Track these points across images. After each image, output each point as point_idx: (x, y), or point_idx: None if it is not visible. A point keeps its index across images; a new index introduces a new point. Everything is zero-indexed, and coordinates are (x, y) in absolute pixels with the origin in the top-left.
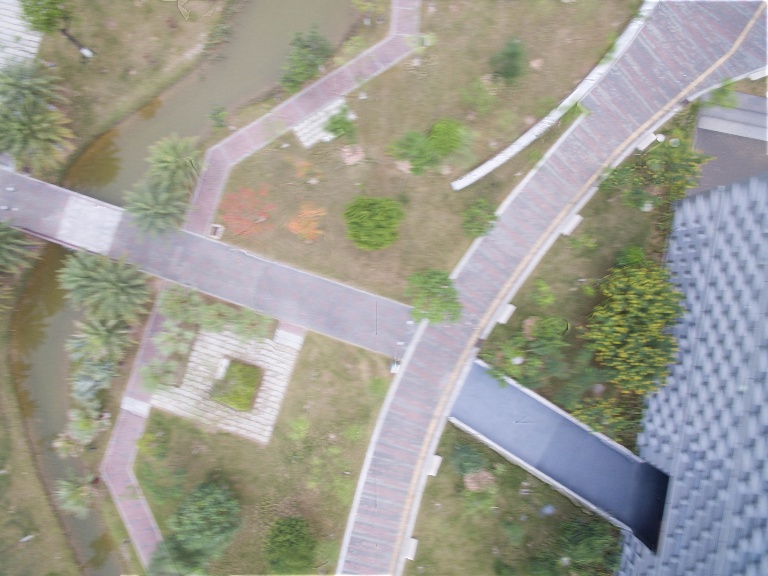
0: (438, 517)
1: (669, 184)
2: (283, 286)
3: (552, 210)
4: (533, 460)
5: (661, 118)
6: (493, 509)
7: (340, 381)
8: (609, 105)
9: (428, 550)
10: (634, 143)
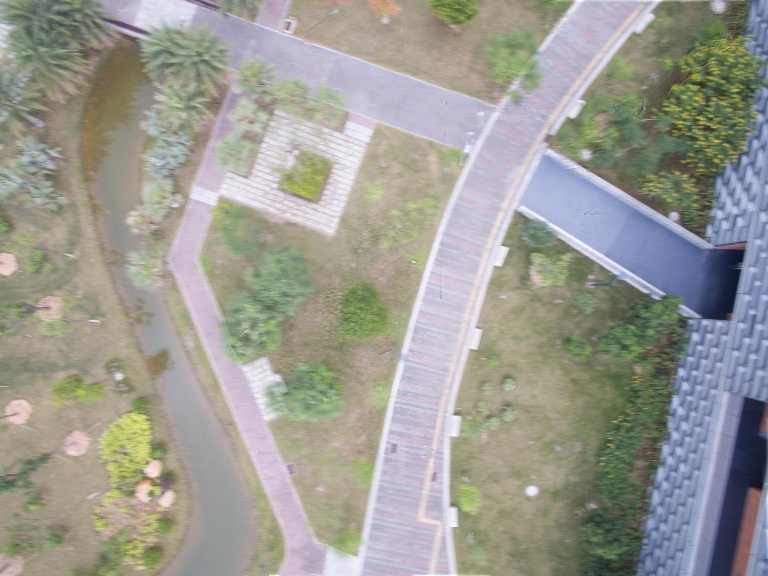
0: (503, 309)
1: None
2: (354, 78)
3: (624, 10)
4: (602, 249)
5: None
6: (558, 303)
7: (408, 172)
8: None
9: (492, 342)
10: None
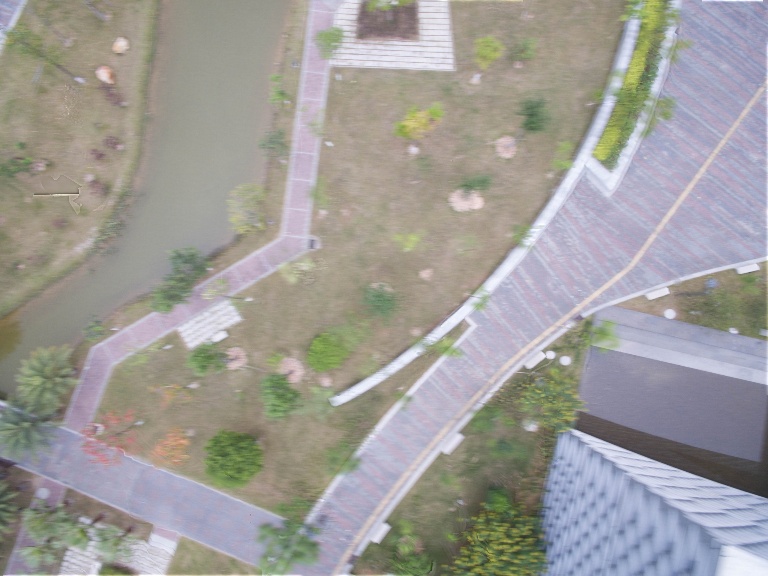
0: None
1: (557, 404)
2: (159, 490)
3: (434, 426)
4: None
5: (553, 334)
6: None
7: None
8: (499, 319)
9: None
10: (523, 359)
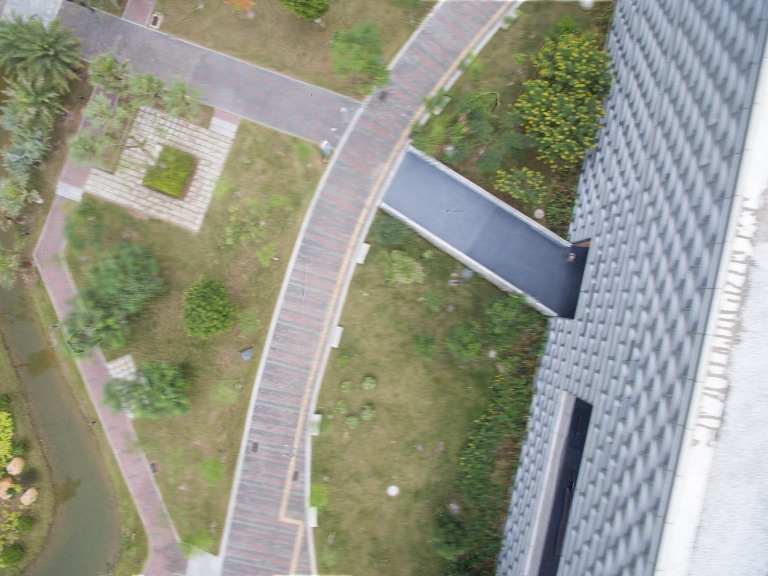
0: (366, 307)
1: None
2: (219, 74)
3: (492, 5)
4: (461, 246)
5: None
6: (421, 301)
7: (272, 169)
8: None
9: (354, 340)
10: None
